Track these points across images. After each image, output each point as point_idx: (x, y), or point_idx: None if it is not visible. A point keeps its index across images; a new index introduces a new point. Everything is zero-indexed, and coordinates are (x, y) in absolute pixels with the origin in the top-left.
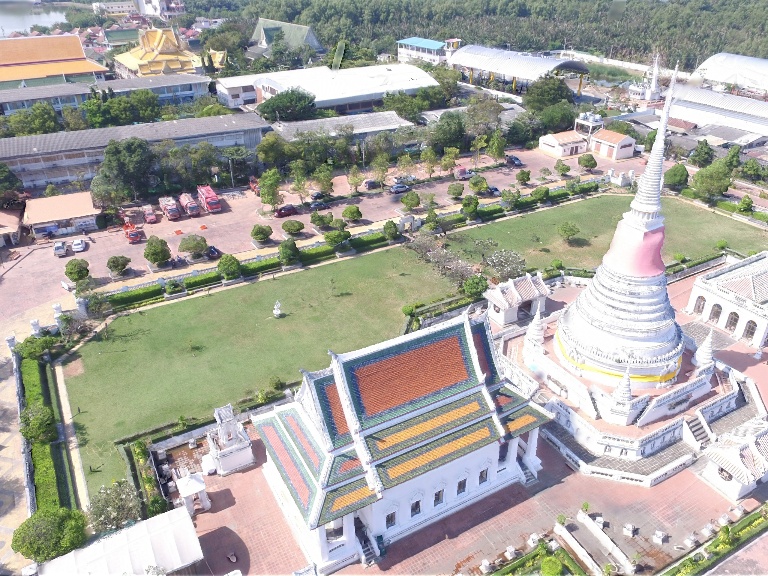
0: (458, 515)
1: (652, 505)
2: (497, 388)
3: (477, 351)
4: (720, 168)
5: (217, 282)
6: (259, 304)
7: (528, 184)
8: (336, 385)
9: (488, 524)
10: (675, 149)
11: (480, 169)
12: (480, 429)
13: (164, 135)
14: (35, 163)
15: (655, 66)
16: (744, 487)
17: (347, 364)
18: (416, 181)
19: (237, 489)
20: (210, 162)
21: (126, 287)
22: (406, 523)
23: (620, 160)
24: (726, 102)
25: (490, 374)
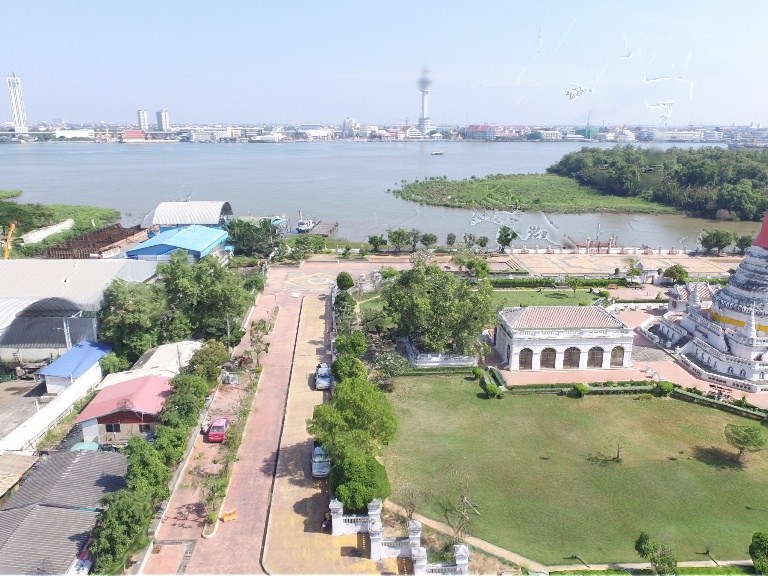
0: None
1: None
2: None
3: None
4: None
5: None
6: None
7: None
8: None
9: None
10: None
11: None
12: None
13: None
14: None
15: None
16: None
17: None
18: None
19: None
20: None
21: None
22: None
23: None
24: None
25: None
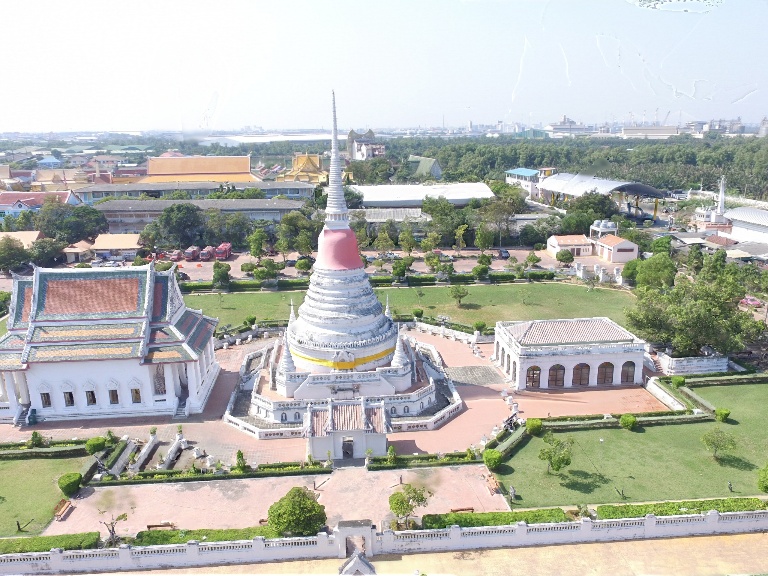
0: (106, 420)
1: (242, 448)
2: (162, 326)
3: (156, 296)
4: (658, 259)
5: None
6: None
7: (490, 268)
8: None
9: (116, 428)
10: (678, 256)
11: (464, 256)
12: (125, 347)
13: (219, 207)
14: (130, 218)
15: (720, 188)
16: (321, 450)
17: (44, 275)
18: (395, 258)
19: None
20: (243, 228)
21: None
22: (62, 410)
23: (617, 263)
24: None
25: (160, 315)
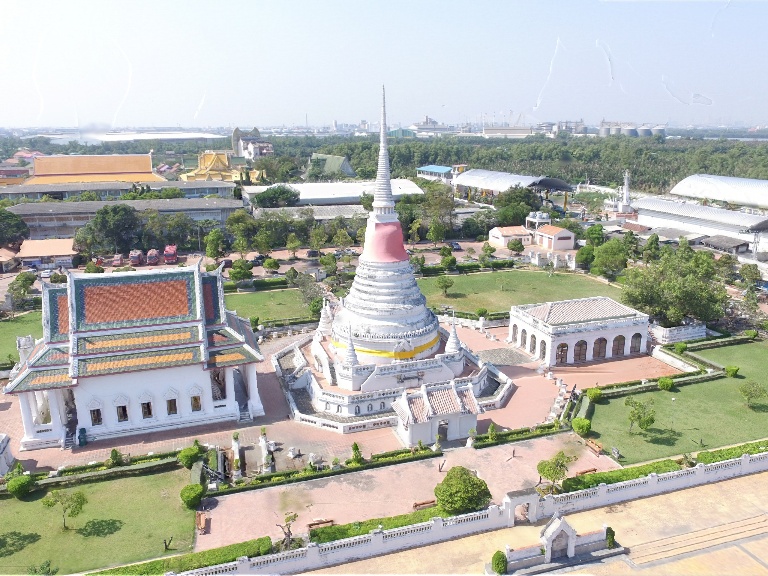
0: (165, 432)
1: (332, 443)
2: (217, 329)
3: (206, 297)
4: (613, 244)
5: None
6: None
7: None
8: (68, 297)
9: (183, 439)
10: None
11: None
12: (185, 353)
13: (154, 207)
14: (50, 222)
15: (625, 181)
16: (419, 436)
17: (79, 282)
18: (353, 254)
19: (17, 403)
20: (185, 230)
21: None
22: (114, 427)
23: (558, 251)
24: (682, 209)
25: (213, 317)
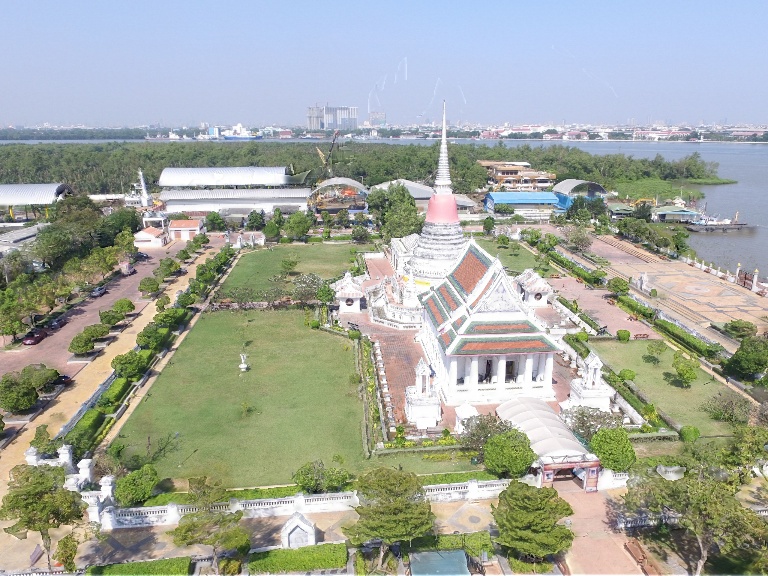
0: None
1: None
2: None
3: None
4: (304, 215)
5: (131, 387)
6: (208, 376)
7: (187, 262)
8: None
9: None
10: (231, 224)
11: None
12: None
13: None
14: None
15: (141, 179)
16: None
17: None
18: (97, 285)
19: None
20: None
21: (64, 427)
22: None
23: None
24: (216, 194)
25: None
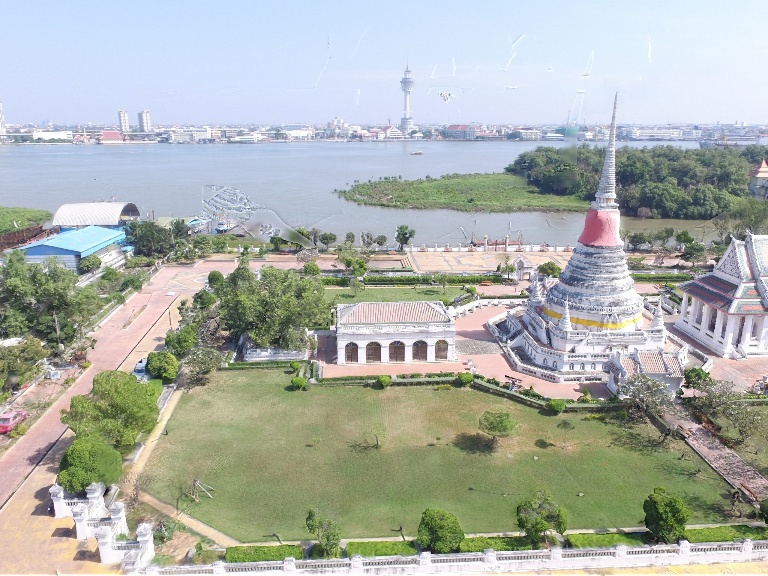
0: None
1: None
2: None
3: None
4: None
5: None
6: None
7: None
8: None
9: None
10: None
11: None
12: None
13: None
14: None
15: None
16: None
17: None
18: None
19: None
20: None
21: None
22: None
23: None
24: None
25: None
